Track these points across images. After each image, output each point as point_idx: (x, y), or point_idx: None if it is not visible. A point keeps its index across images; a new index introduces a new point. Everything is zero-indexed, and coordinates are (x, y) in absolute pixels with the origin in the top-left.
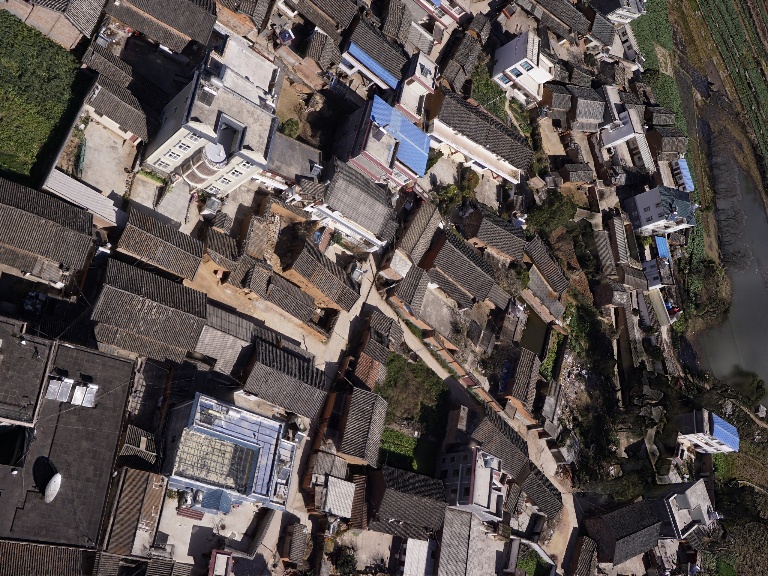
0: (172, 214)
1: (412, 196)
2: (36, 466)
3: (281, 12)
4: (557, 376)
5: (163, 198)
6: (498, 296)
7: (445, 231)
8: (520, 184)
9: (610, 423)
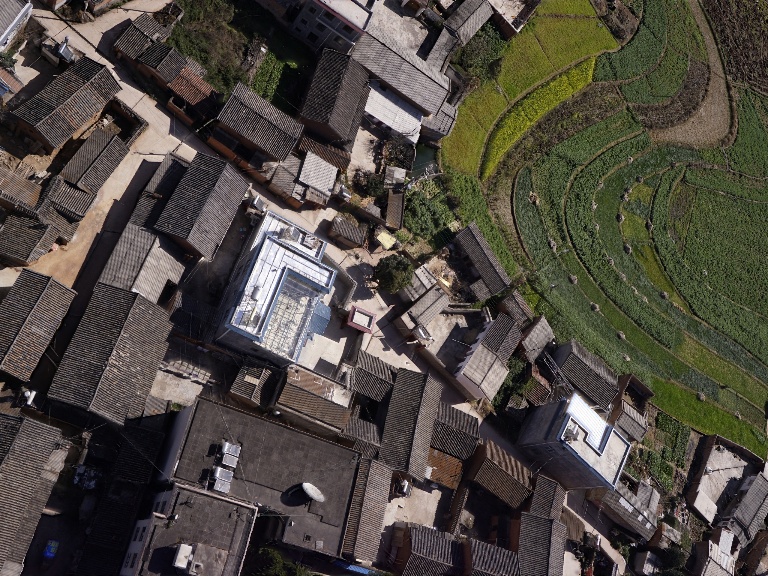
0: None
1: None
2: (288, 504)
3: None
4: None
5: None
6: None
7: None
8: None
9: None
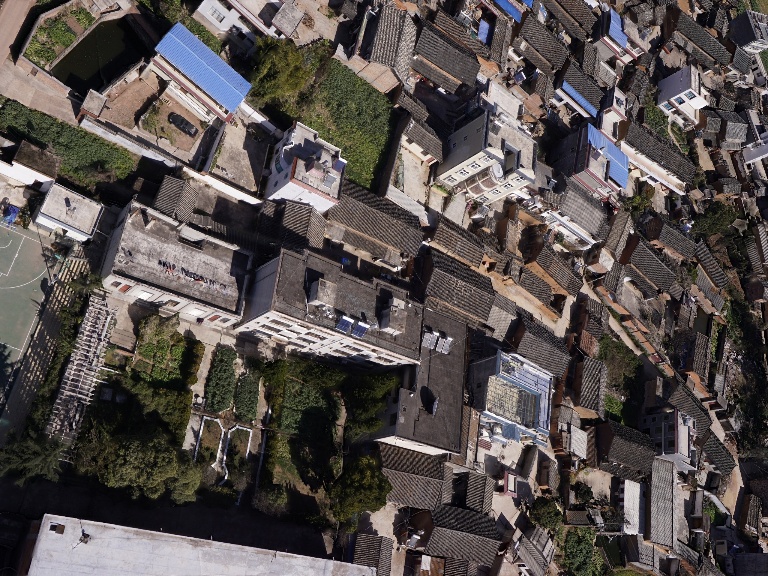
0: (454, 218)
1: (606, 205)
2: (422, 392)
3: (509, 57)
4: (720, 359)
5: (449, 205)
6: (674, 289)
7: (637, 234)
8: (682, 195)
9: (762, 402)
